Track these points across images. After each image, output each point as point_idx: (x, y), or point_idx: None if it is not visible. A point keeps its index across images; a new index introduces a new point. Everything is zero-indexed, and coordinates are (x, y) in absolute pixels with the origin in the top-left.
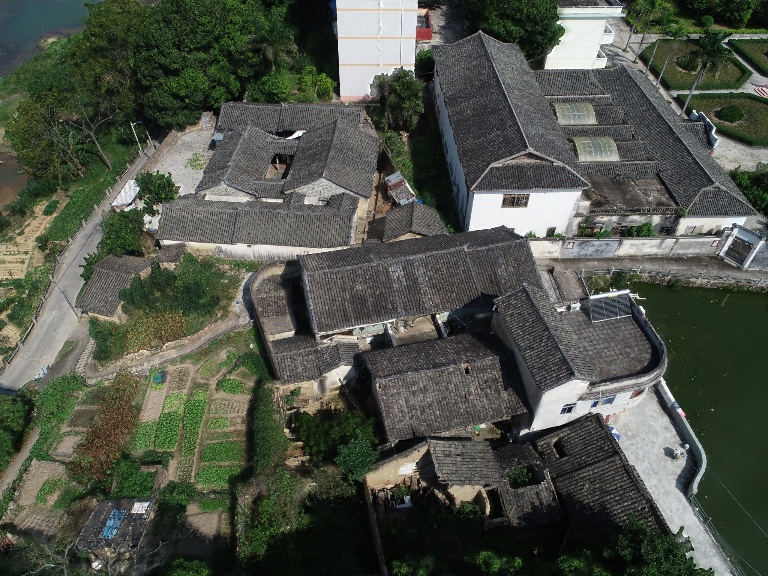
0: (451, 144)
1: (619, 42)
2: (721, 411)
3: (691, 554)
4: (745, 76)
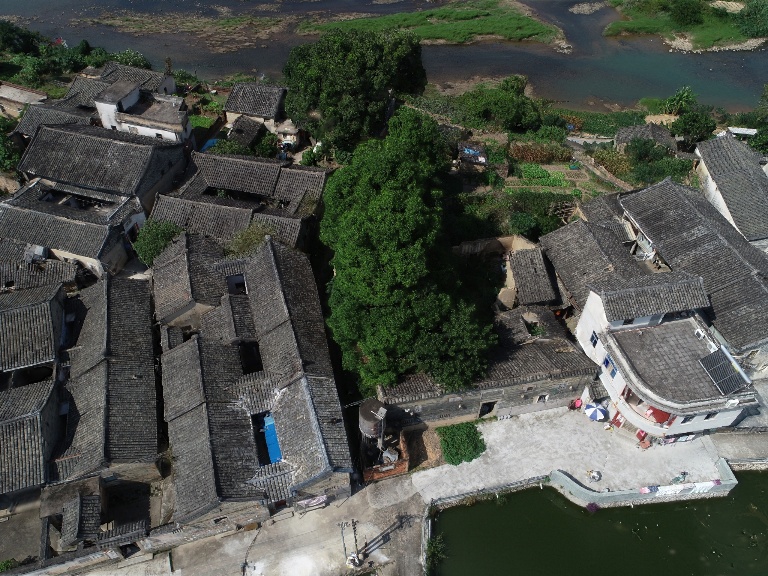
0: None
1: None
2: (674, 568)
3: (497, 461)
4: None
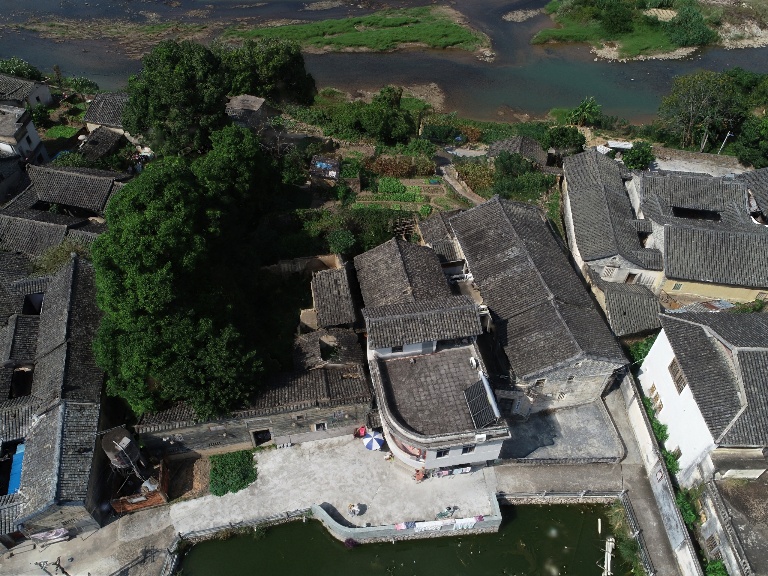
0: None
1: None
2: None
3: (264, 492)
4: None
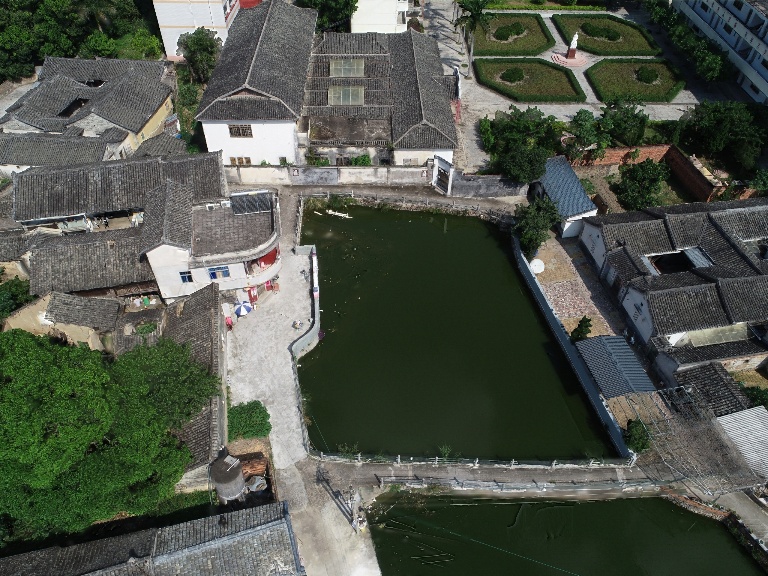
0: None
1: (452, 16)
2: None
3: (273, 394)
4: (546, 44)
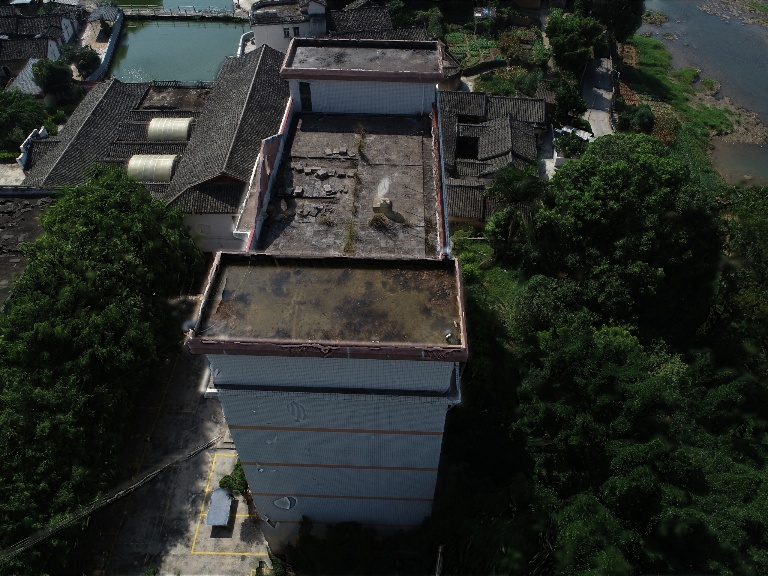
0: None
1: None
2: None
3: None
4: None
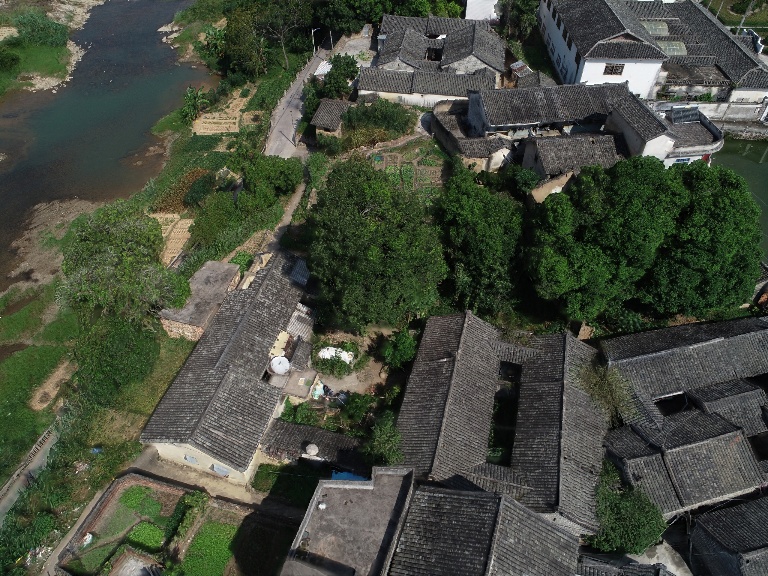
0: (559, 44)
1: None
2: None
3: None
4: None
